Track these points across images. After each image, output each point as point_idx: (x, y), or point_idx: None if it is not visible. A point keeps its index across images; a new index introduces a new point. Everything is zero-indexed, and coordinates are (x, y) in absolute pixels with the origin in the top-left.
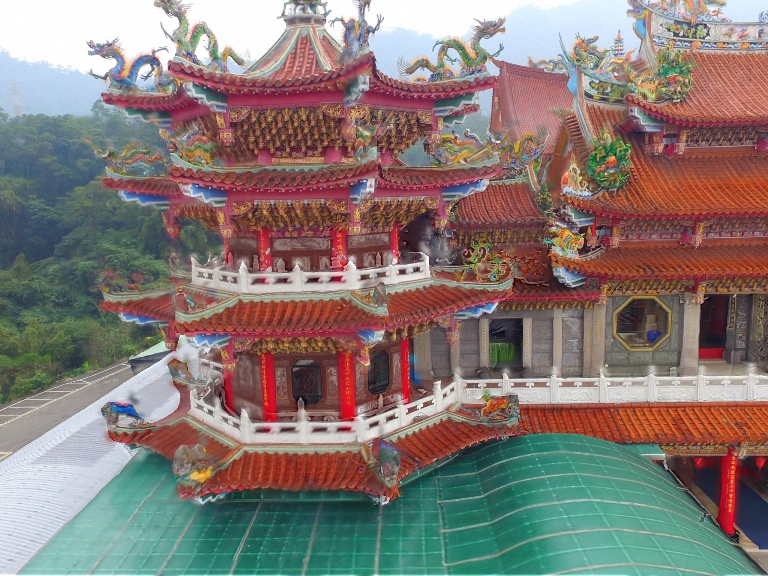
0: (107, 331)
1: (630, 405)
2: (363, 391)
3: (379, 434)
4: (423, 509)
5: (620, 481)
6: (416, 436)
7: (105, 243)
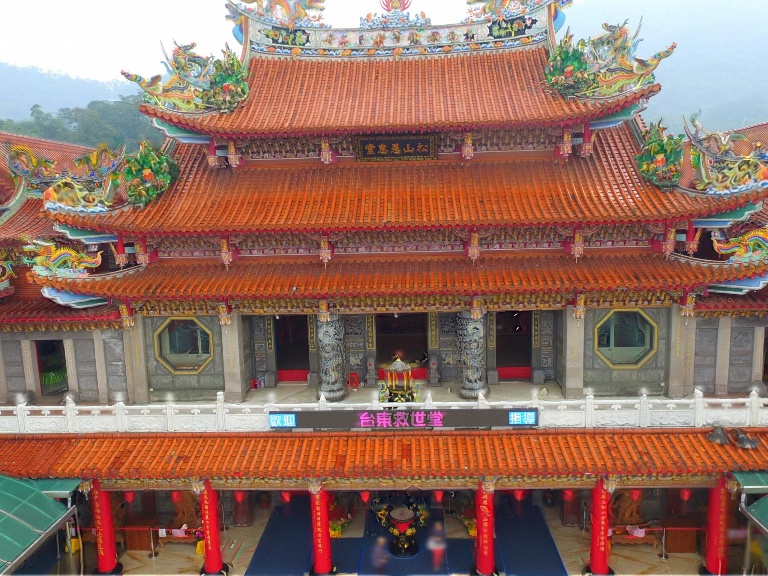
0: None
1: (93, 435)
2: None
3: None
4: None
5: None
6: None
7: None
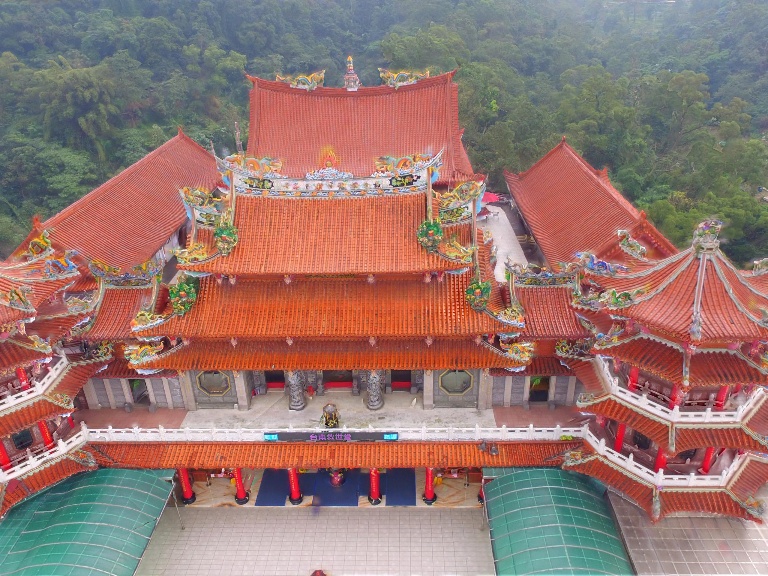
0: (21, 224)
1: (176, 443)
2: (13, 450)
3: (16, 476)
4: (24, 518)
5: (113, 507)
6: (41, 472)
7: (12, 132)
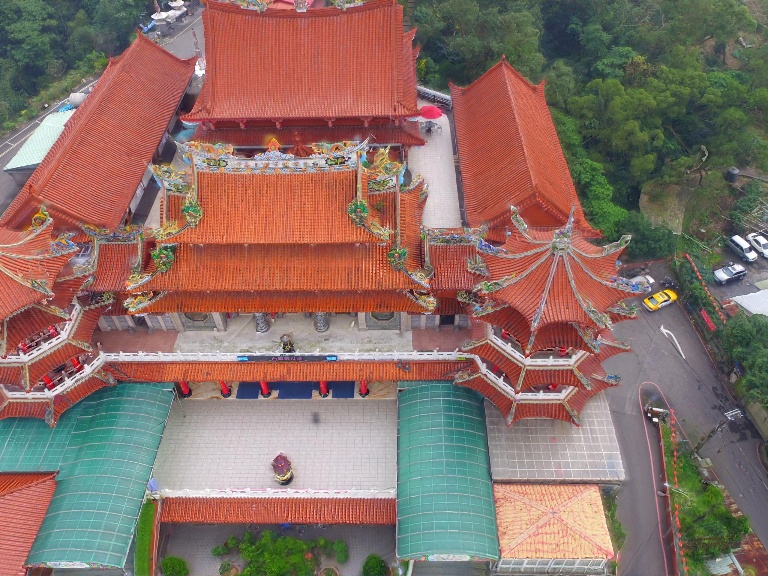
0: None
1: (172, 363)
2: (52, 374)
3: (58, 392)
4: (71, 421)
5: (133, 415)
6: (76, 388)
7: None
